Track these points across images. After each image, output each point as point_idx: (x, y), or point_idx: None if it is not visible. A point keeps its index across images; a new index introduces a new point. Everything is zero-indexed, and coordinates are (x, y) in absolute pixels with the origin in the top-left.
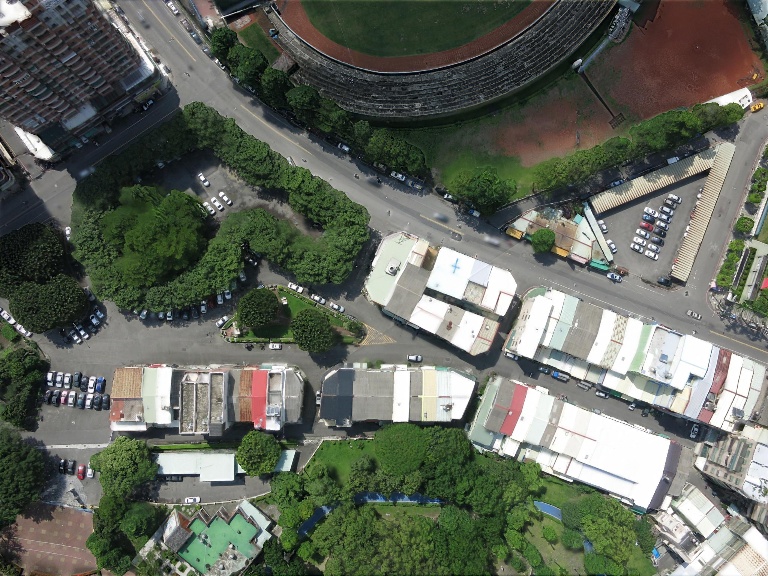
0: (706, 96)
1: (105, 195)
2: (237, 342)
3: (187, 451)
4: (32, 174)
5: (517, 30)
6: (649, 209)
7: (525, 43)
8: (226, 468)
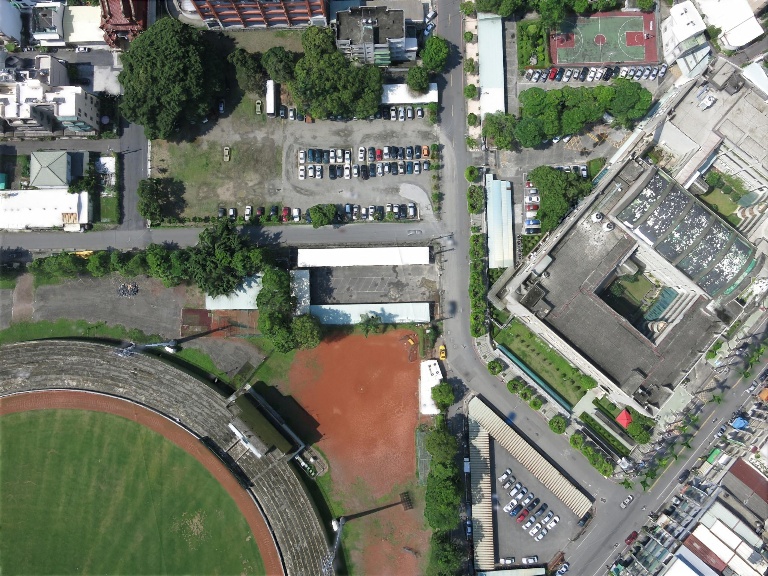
0: (413, 400)
1: None
2: None
3: None
4: None
5: (278, 569)
6: (507, 509)
7: (296, 570)
8: None
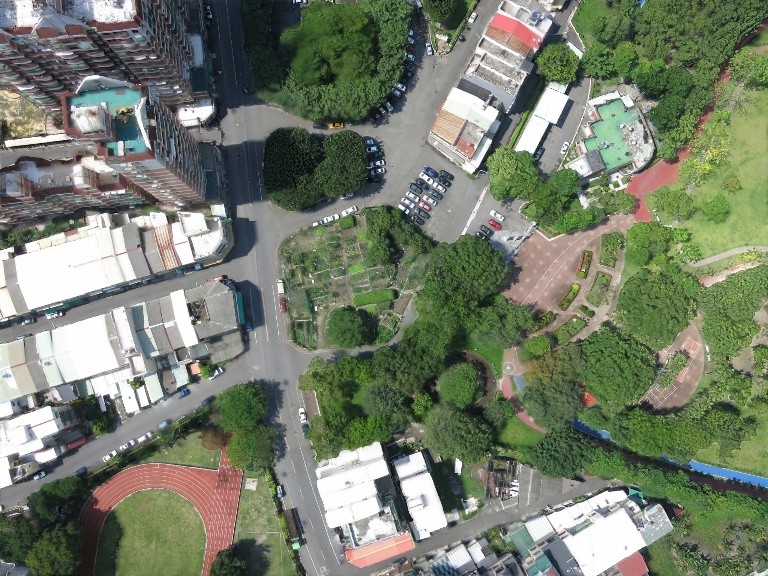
0: None
1: (277, 63)
2: (453, 47)
3: (522, 132)
4: (216, 139)
5: None
6: None
7: None
8: (556, 98)
